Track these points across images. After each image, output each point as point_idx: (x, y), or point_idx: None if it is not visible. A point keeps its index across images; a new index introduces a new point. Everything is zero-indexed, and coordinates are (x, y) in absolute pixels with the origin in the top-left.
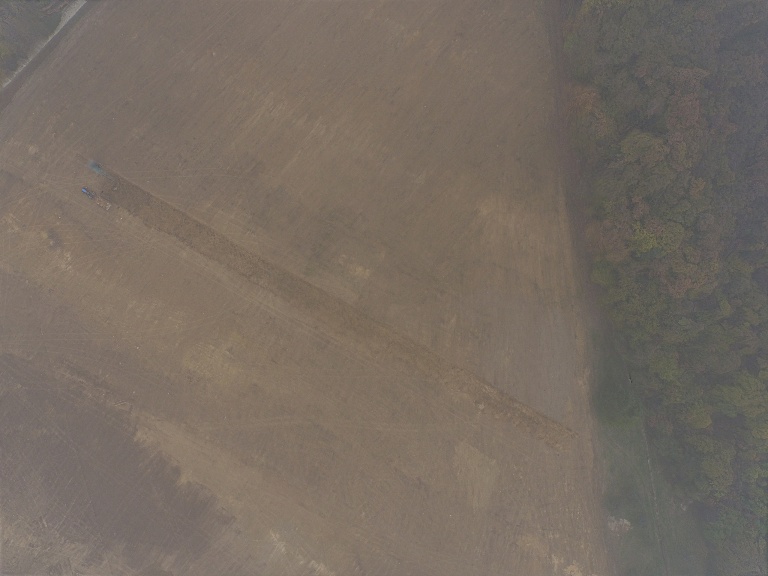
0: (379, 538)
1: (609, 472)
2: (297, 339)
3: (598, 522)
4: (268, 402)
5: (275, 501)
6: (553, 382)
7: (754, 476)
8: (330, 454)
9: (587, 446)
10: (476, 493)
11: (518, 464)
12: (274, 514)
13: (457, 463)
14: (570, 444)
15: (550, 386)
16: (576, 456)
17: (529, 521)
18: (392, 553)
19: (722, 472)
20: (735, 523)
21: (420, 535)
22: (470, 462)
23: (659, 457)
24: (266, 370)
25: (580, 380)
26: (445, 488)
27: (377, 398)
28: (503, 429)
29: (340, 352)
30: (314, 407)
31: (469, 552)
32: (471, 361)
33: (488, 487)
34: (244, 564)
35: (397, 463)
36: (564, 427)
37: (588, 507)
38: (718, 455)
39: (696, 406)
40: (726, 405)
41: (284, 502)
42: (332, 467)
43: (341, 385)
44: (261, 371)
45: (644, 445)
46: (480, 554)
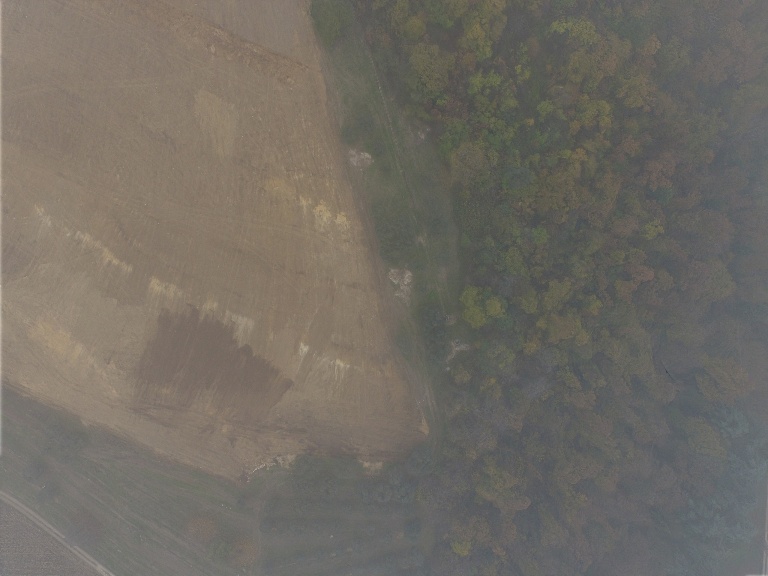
0: (136, 200)
1: (343, 104)
2: (34, 4)
3: (340, 158)
4: (15, 72)
5: (35, 174)
6: (278, 16)
7: (475, 82)
8: (79, 118)
9: (318, 78)
10: (220, 141)
11: (255, 105)
12: (36, 188)
13: (198, 112)
14: (301, 78)
15: (276, 21)
16: (309, 90)
17: (273, 163)
18: (150, 214)
19: (427, 62)
20: (461, 132)
21: (174, 192)
22: (210, 110)
23: (389, 83)
24: (10, 40)
25: (304, 11)
26: (190, 139)
27: (116, 55)
28: (237, 71)
29: (76, 13)
30: (58, 72)
31: (222, 204)
32: (199, 5)
33: (230, 133)
34: (16, 244)
35: (142, 119)
36: (295, 62)
37: (328, 143)
38: (426, 51)
39: (397, 0)
40: (437, 8)
41: (44, 174)
42: (83, 131)
43: (81, 46)
44: (5, 42)
45: (373, 71)
46: (232, 204)
